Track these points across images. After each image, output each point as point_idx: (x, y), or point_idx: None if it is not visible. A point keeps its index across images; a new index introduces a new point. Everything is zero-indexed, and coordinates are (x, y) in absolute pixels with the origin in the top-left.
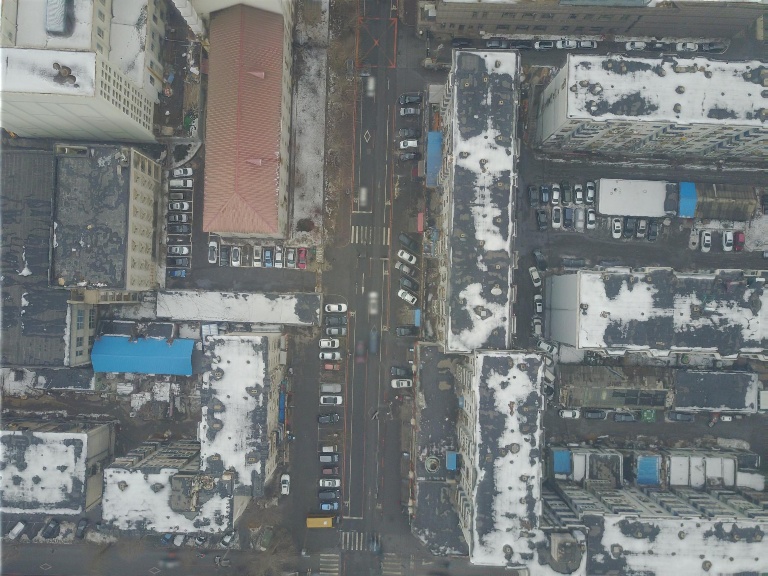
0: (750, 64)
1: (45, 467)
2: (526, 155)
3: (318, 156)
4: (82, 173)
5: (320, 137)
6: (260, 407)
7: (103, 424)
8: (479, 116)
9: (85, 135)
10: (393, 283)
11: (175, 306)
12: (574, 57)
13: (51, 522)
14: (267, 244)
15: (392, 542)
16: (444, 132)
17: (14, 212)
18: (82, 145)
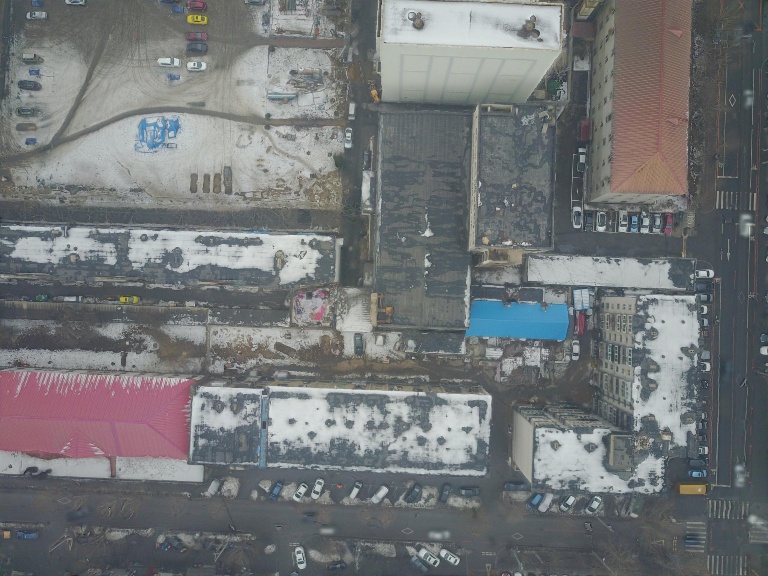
0: None
1: (450, 428)
2: None
3: None
4: (506, 132)
5: None
6: (695, 367)
7: (480, 388)
8: None
9: (458, 98)
10: (761, 249)
11: (547, 270)
12: None
13: (416, 486)
14: (633, 209)
15: (761, 511)
16: None
17: (416, 173)
18: (508, 103)
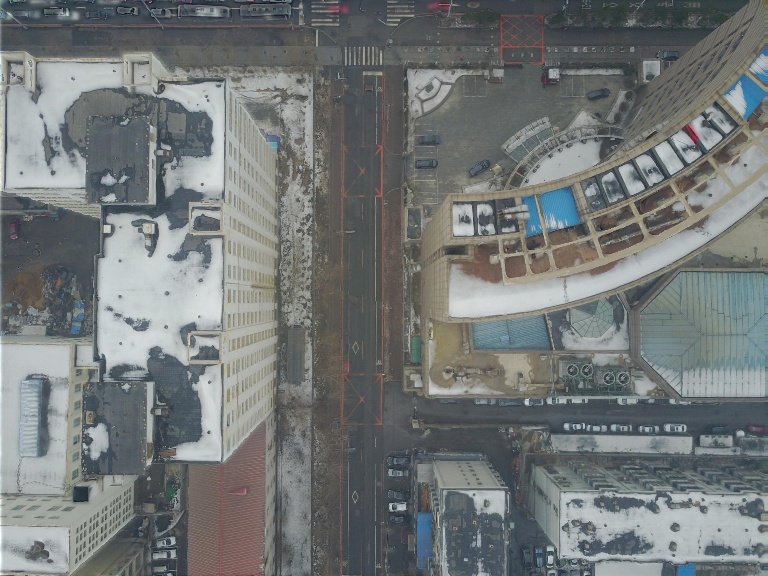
0: (746, 496)
1: None
2: (519, 514)
3: (305, 520)
4: None
5: (307, 500)
6: None
7: None
8: (469, 559)
9: None
10: None
11: None
12: (565, 494)
13: None
14: None
15: None
16: (434, 525)
17: None
18: None
